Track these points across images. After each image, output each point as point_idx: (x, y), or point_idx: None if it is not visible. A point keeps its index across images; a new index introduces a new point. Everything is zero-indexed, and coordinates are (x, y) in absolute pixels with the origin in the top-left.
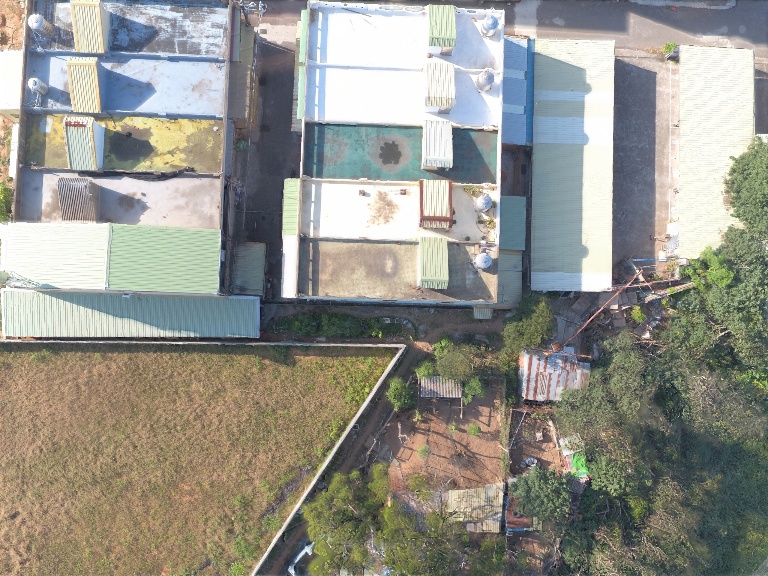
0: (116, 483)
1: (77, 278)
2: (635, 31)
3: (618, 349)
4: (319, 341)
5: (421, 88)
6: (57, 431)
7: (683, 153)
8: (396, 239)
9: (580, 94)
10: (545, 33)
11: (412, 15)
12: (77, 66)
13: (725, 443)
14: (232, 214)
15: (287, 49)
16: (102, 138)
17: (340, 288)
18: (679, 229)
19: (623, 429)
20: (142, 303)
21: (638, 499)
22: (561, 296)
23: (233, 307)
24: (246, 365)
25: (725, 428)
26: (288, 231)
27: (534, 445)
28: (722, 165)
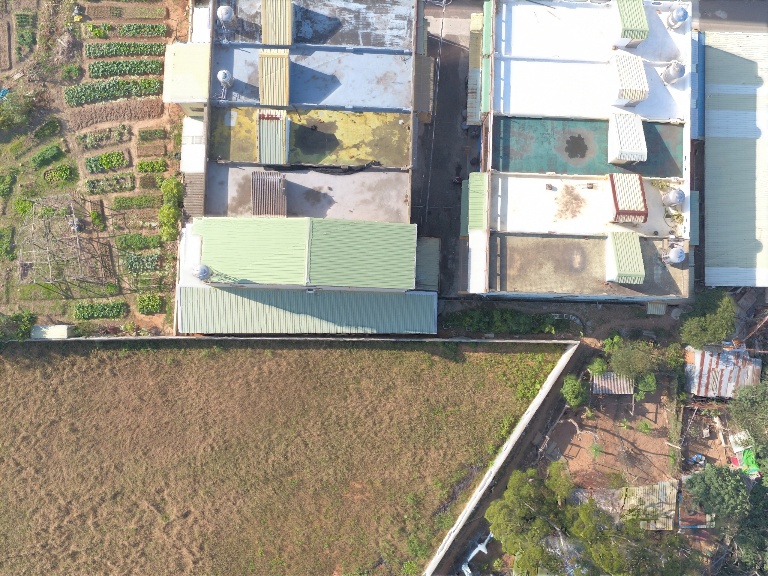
0: (287, 481)
1: (277, 273)
2: None
3: None
4: (487, 337)
5: (613, 81)
6: (228, 429)
7: None
8: (585, 234)
9: (752, 87)
10: (708, 26)
11: (596, 7)
12: (269, 58)
13: None
14: None
15: (451, 42)
16: (288, 131)
17: (528, 283)
18: None
19: None
20: (319, 299)
21: None
22: (728, 291)
23: (411, 303)
24: (416, 362)
25: None
26: (474, 226)
27: (700, 442)
28: None
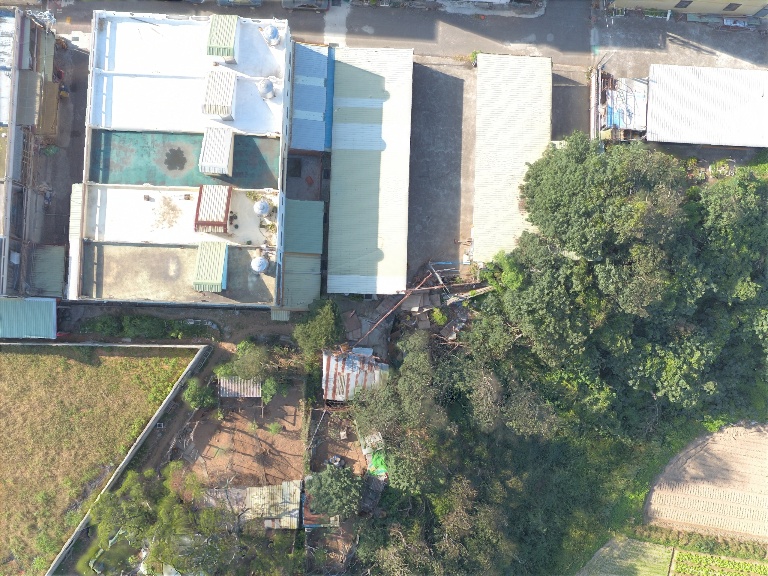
0: None
1: None
2: (444, 39)
3: (408, 350)
4: (125, 342)
5: (199, 96)
6: None
7: (479, 159)
8: (178, 243)
9: (378, 101)
10: (354, 41)
11: (199, 24)
12: None
13: (550, 442)
14: (39, 218)
15: None
16: None
17: (124, 291)
18: (474, 233)
19: (430, 428)
20: None
21: (440, 496)
22: (365, 298)
23: (30, 309)
24: (51, 365)
25: (517, 428)
26: (74, 235)
27: (339, 444)
28: (518, 171)
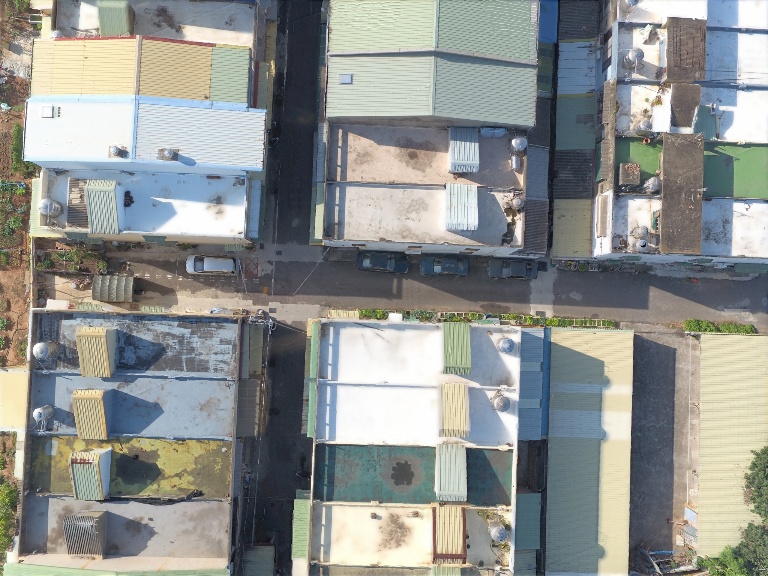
0: None
1: None
2: (654, 305)
3: None
4: None
5: (435, 417)
6: None
7: (703, 448)
8: (408, 566)
9: (597, 386)
10: (562, 308)
11: (426, 329)
12: (83, 400)
13: None
14: (241, 505)
15: (297, 329)
16: (108, 462)
17: None
18: (698, 527)
19: None
20: None
21: None
22: None
23: None
24: None
25: None
26: (298, 554)
27: None
28: (743, 459)
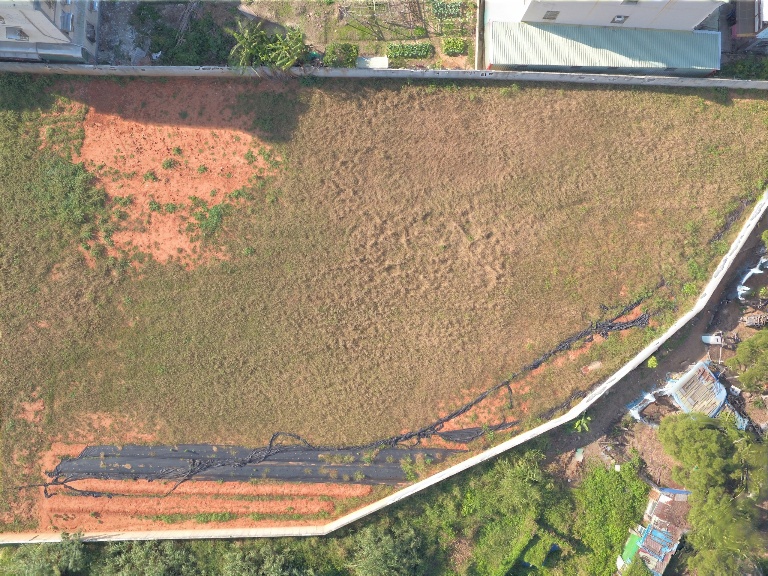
0: (578, 208)
1: None
2: None
3: None
4: None
5: None
6: (525, 160)
7: None
8: None
9: None
10: None
11: None
12: None
13: None
14: None
15: None
16: None
17: None
18: None
19: None
20: (616, 35)
21: None
22: None
23: (697, 41)
24: (691, 105)
25: None
26: None
27: None
28: None
